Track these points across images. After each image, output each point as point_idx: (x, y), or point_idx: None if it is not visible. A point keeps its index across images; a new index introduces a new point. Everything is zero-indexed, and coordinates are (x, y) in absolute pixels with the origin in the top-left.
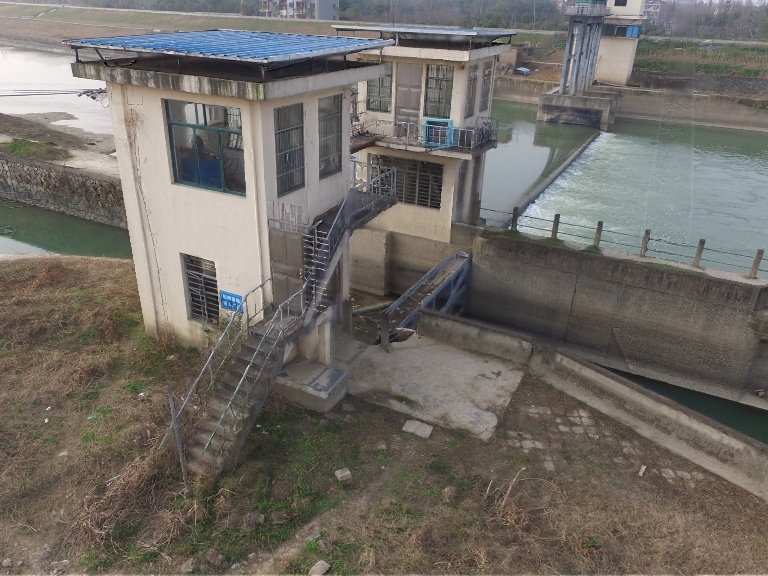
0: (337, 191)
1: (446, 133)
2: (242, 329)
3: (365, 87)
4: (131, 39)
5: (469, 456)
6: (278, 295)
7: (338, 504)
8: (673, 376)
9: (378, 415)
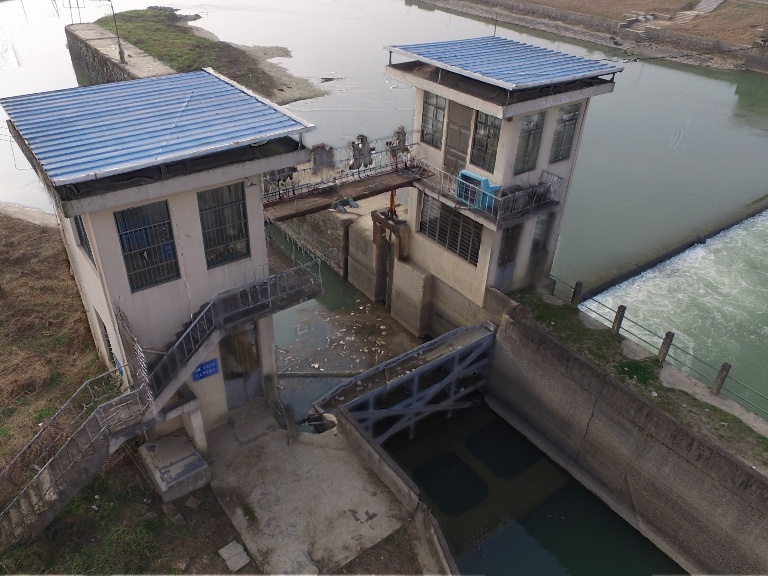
0: (244, 276)
1: (476, 194)
2: (121, 395)
3: (420, 116)
4: (66, 97)
5: None
6: (135, 381)
7: None
8: (687, 561)
9: (211, 523)
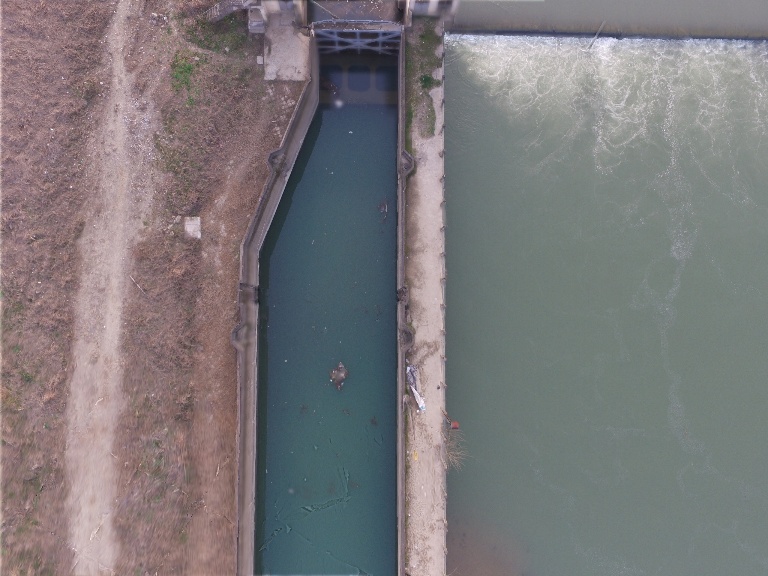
0: None
1: None
2: None
3: None
4: None
5: (256, 77)
6: None
7: (219, 53)
8: None
9: (259, 47)
